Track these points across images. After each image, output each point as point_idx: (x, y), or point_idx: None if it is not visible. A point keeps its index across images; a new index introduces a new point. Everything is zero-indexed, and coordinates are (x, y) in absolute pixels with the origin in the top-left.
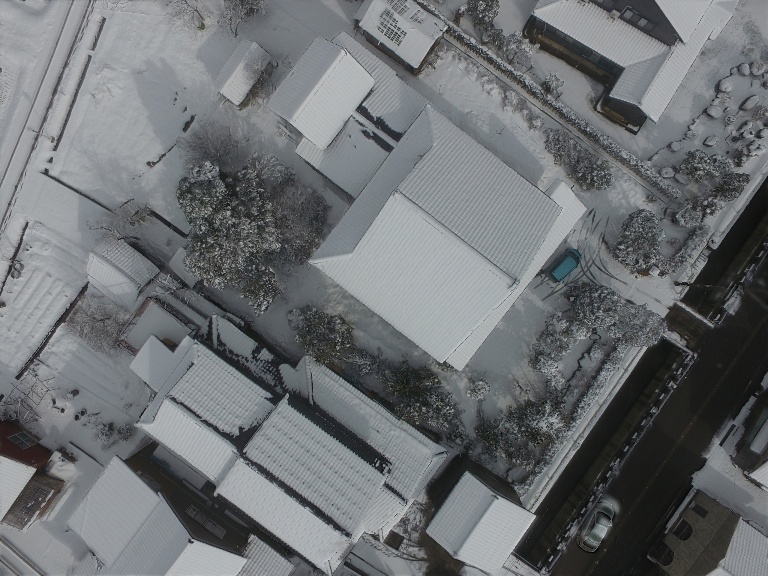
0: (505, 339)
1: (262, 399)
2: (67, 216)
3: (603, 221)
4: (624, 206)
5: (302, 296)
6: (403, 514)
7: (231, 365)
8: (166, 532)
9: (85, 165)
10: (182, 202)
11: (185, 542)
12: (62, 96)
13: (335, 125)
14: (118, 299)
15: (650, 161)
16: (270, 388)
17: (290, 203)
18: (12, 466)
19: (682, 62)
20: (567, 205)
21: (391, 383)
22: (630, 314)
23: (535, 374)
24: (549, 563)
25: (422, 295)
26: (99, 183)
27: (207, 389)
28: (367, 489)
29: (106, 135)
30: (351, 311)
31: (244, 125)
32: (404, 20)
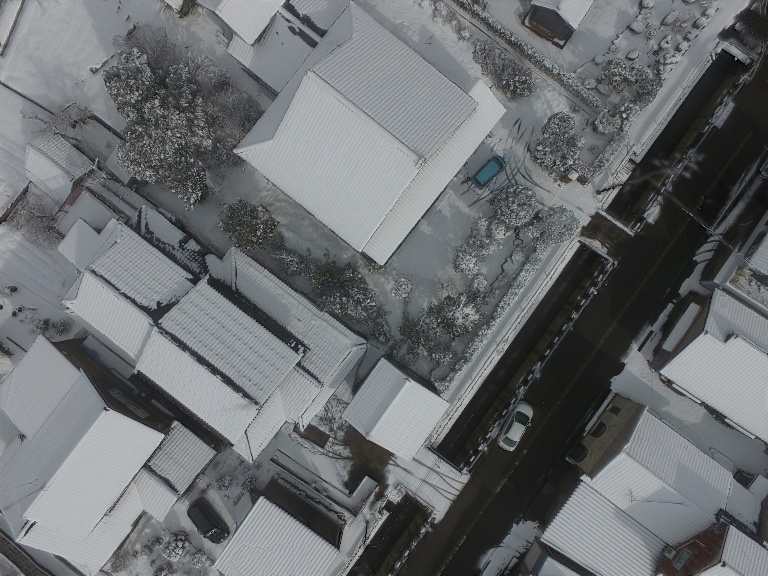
0: (432, 244)
1: (182, 279)
2: (10, 118)
3: (528, 131)
4: (548, 116)
5: (235, 198)
6: (324, 404)
7: (154, 246)
8: (84, 403)
9: (30, 69)
10: (109, 85)
11: (101, 409)
12: (9, 2)
13: (261, 19)
14: (54, 193)
15: (574, 73)
16: (195, 275)
17: (221, 100)
18: None
19: None
20: (486, 104)
21: (313, 274)
22: (548, 214)
23: (460, 278)
24: (470, 463)
25: (338, 179)
26: (43, 87)
27: (128, 265)
28: (280, 365)
29: (51, 41)
30: (282, 213)
31: (184, 32)
32: None
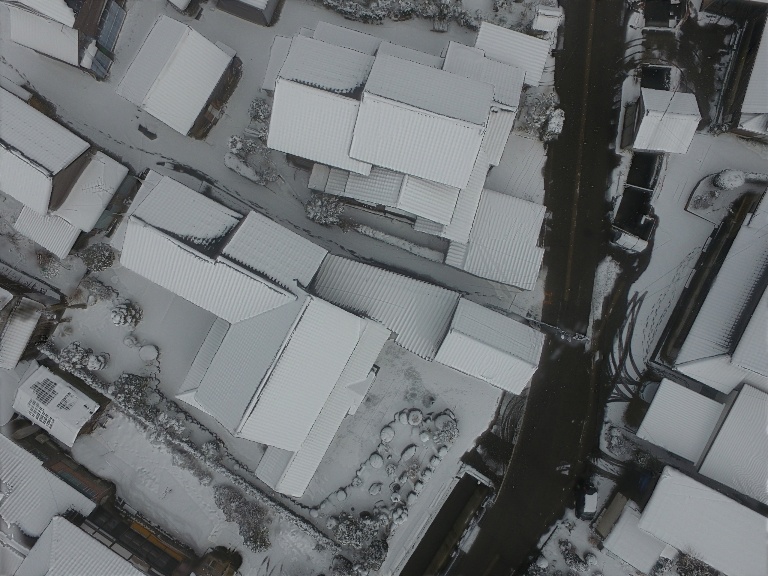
0: None
1: None
2: None
3: (277, 568)
4: (295, 554)
5: None
6: None
7: None
8: None
9: None
10: None
11: None
12: None
13: None
14: None
15: (319, 509)
16: None
17: None
18: None
19: (318, 443)
20: None
21: None
22: None
23: None
24: None
25: None
26: None
27: None
28: None
29: None
30: None
31: None
32: (48, 410)
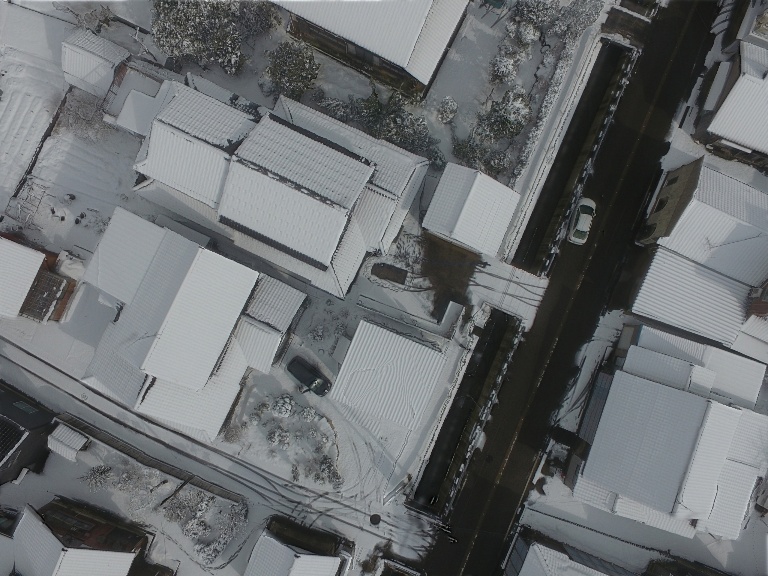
0: (464, 69)
1: (245, 119)
2: (35, 36)
3: None
4: None
5: None
6: (399, 227)
7: None
8: (177, 252)
9: None
10: None
11: (196, 249)
12: None
13: None
14: (96, 88)
15: None
16: None
17: None
18: (22, 250)
19: None
20: None
21: (364, 103)
22: None
23: (498, 95)
24: (546, 267)
25: None
26: (60, 2)
27: (191, 113)
28: (357, 177)
29: None
30: None
31: None
32: None
